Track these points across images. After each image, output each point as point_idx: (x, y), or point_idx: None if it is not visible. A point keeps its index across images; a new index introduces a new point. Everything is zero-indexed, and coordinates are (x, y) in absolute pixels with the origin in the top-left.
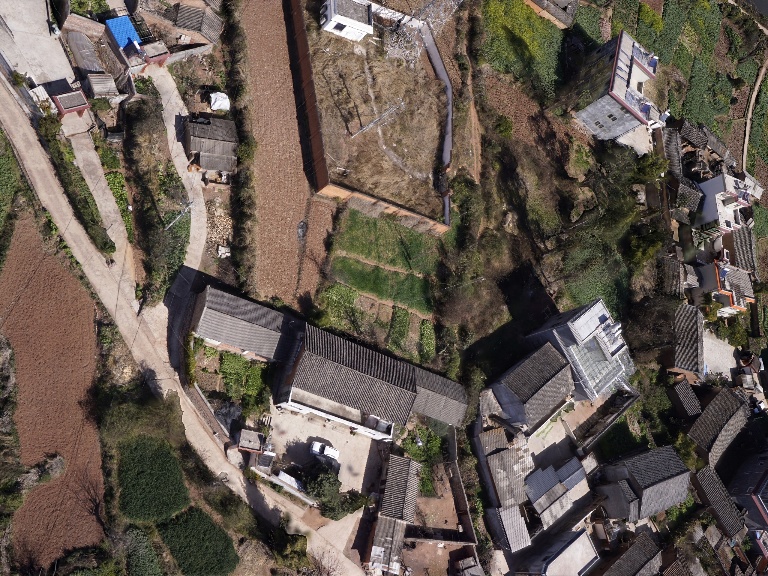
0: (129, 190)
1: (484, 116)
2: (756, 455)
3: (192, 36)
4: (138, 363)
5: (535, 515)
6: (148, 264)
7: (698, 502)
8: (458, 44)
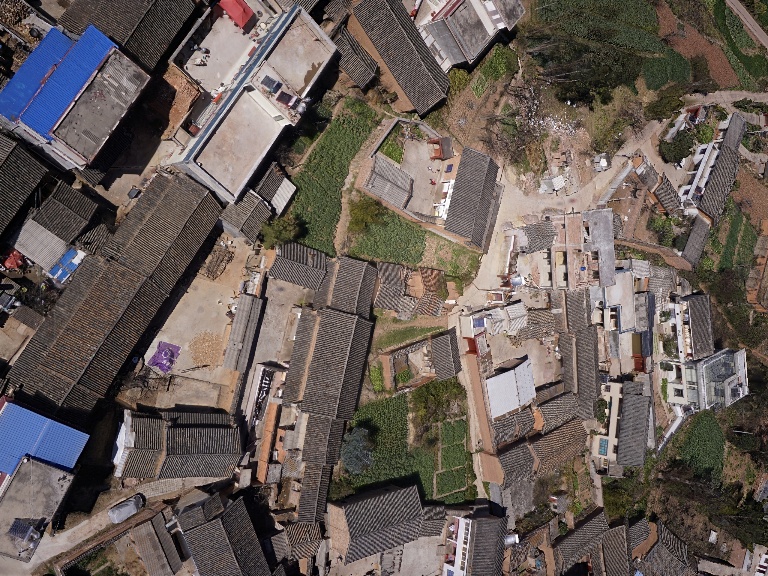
0: None
1: None
2: None
3: None
4: None
5: None
6: None
7: None
8: None
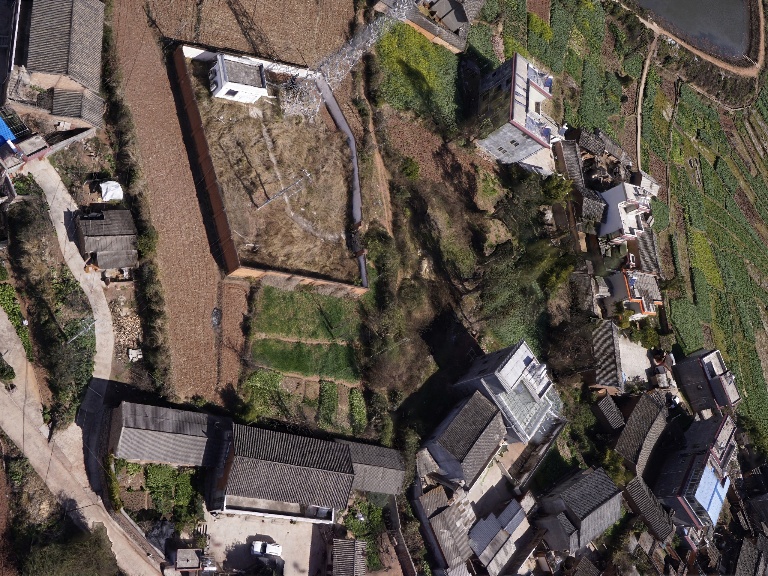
0: (22, 302)
1: (389, 161)
2: (677, 452)
3: (72, 122)
4: (55, 495)
5: (481, 566)
6: (53, 383)
7: (629, 512)
8: (355, 88)
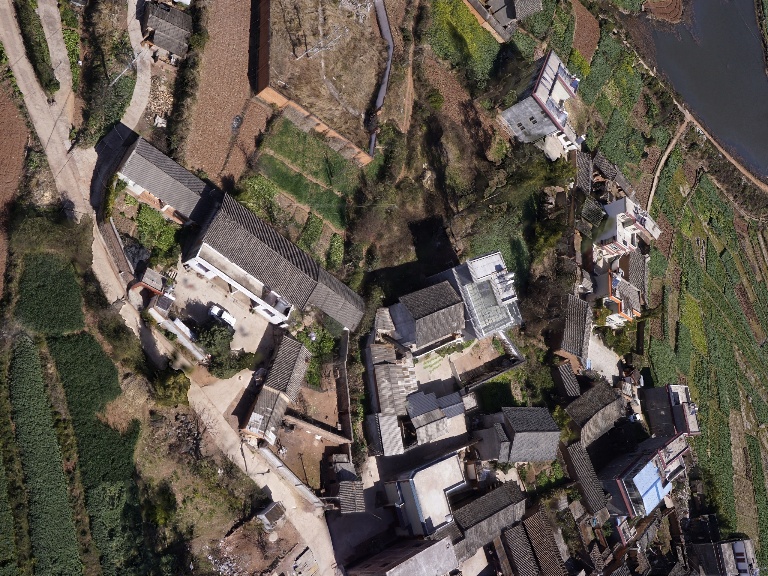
0: (82, 49)
1: (419, 85)
2: (626, 454)
3: None
4: (59, 192)
5: (412, 434)
6: (87, 112)
7: (567, 476)
8: (405, 21)
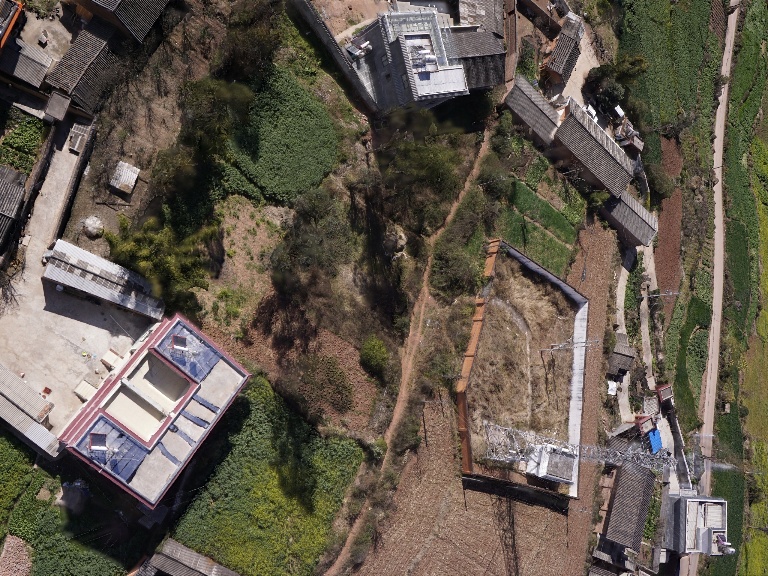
0: None
1: None
2: None
3: None
4: None
5: None
6: None
7: None
8: None
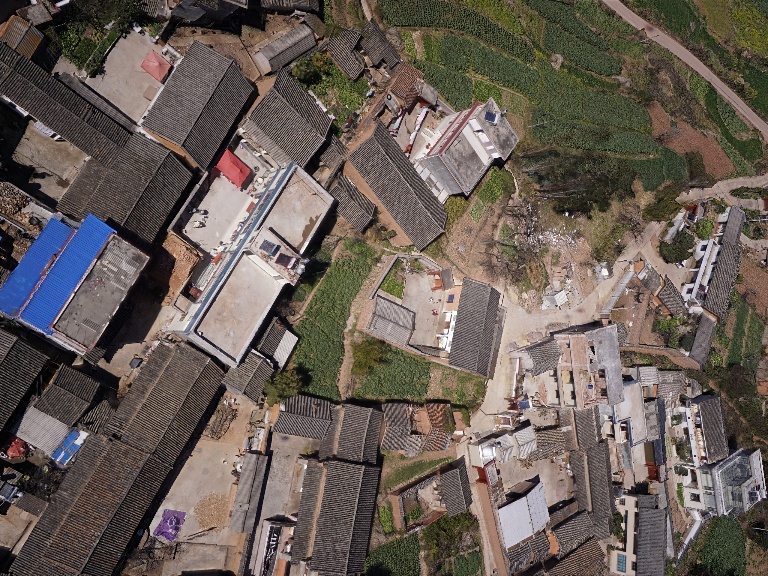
0: None
1: None
2: None
3: None
4: None
5: None
6: None
7: None
8: None
